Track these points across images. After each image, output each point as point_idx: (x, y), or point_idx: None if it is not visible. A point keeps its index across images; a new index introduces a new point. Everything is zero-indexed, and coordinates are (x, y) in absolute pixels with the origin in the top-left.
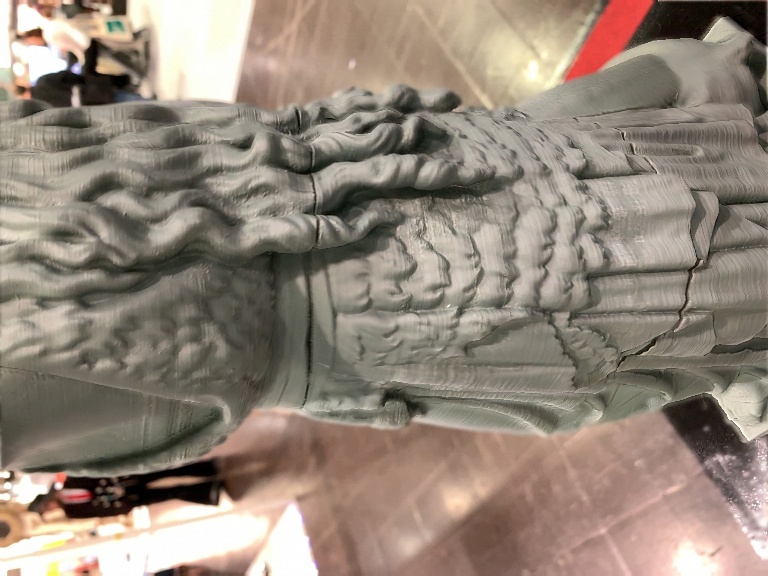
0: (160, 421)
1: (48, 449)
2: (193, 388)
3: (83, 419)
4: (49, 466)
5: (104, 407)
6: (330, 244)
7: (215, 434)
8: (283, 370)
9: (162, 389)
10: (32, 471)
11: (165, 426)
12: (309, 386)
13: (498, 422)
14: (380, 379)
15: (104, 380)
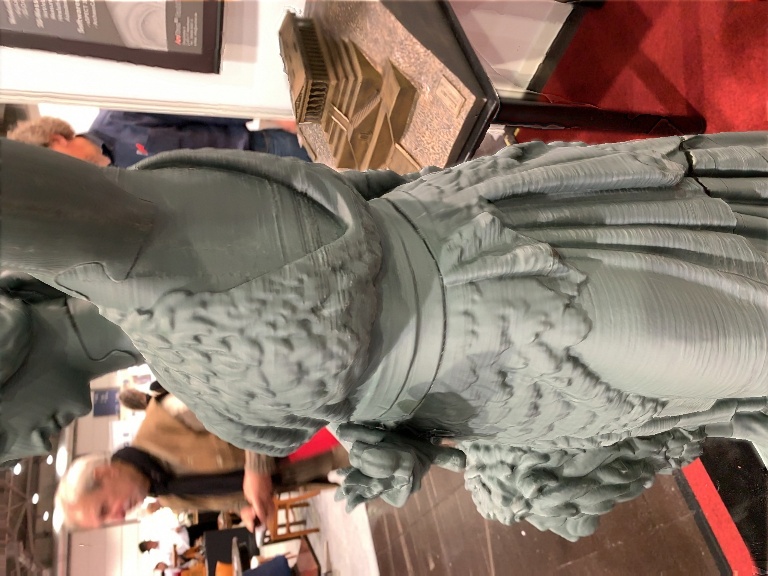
0: (291, 226)
1: (196, 252)
2: (300, 164)
3: (223, 197)
4: (197, 287)
5: (238, 191)
6: (376, 174)
7: (347, 238)
8: (391, 228)
9: (277, 162)
10: (181, 294)
11: (298, 236)
12: (426, 242)
13: (705, 299)
14: (471, 199)
15: (233, 155)
